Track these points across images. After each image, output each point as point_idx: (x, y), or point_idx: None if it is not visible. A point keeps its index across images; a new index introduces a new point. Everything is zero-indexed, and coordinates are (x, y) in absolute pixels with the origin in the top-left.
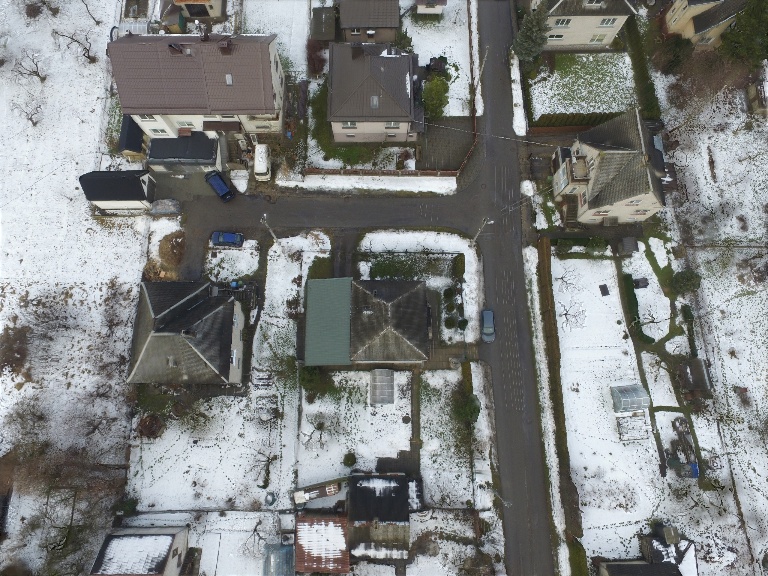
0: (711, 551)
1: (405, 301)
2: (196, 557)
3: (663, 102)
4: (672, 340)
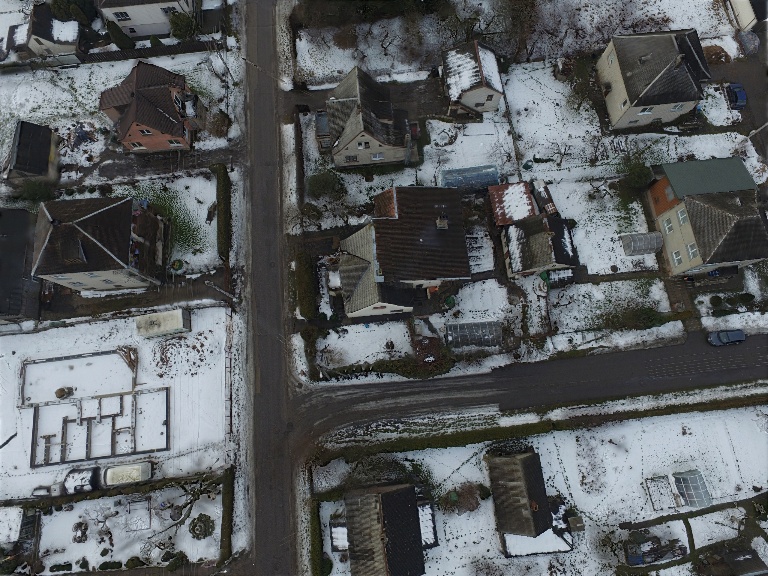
0: (562, 573)
1: (761, 234)
2: (477, 120)
3: None
4: (767, 545)
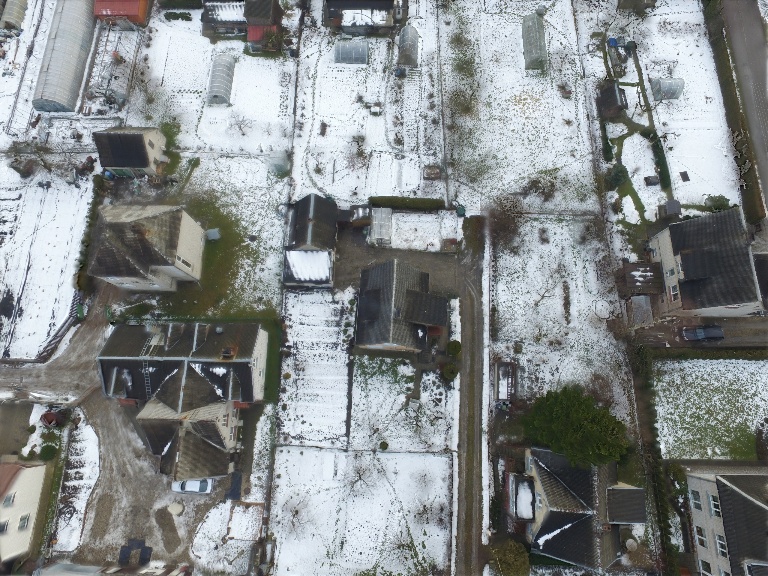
0: None
1: None
2: None
3: (617, 384)
4: None
